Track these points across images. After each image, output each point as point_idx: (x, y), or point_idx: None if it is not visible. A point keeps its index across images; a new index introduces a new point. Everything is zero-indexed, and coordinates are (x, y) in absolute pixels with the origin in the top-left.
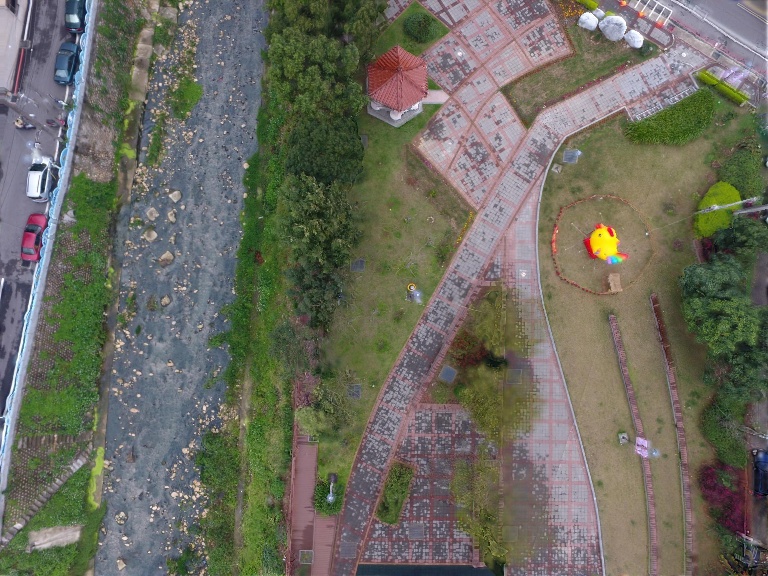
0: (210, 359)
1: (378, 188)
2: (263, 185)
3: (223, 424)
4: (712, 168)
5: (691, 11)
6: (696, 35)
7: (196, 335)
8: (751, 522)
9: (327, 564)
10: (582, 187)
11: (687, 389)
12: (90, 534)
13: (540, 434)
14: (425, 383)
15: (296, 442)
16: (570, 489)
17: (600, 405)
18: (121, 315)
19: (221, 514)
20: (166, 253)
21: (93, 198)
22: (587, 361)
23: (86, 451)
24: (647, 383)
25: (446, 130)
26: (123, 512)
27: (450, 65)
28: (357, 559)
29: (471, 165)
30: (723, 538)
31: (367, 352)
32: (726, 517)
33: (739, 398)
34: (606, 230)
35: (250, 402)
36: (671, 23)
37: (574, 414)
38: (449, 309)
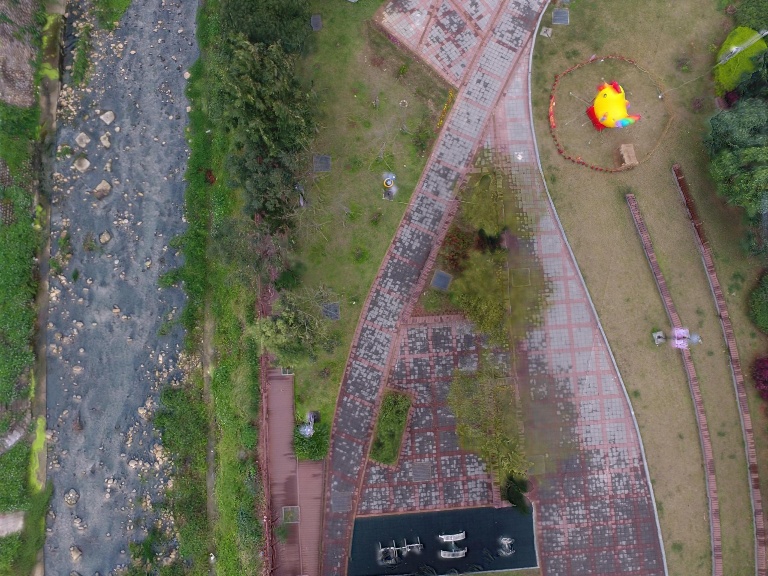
0: (162, 300)
1: (338, 73)
2: (207, 93)
3: (184, 375)
4: (727, 15)
5: None
6: None
7: (144, 274)
8: None
9: (317, 521)
10: (578, 51)
11: (728, 273)
12: (35, 519)
13: (559, 343)
14: (415, 293)
15: (267, 378)
16: (602, 405)
17: (627, 302)
18: (54, 259)
19: (189, 480)
20: (101, 183)
21: (8, 122)
22: (606, 251)
23: (24, 421)
24: (680, 270)
25: (412, 1)
26: (73, 490)
27: None
28: (353, 512)
29: (445, 38)
30: None
31: (343, 264)
32: None
33: None
34: (612, 88)
35: (213, 345)
36: None
37: (597, 315)
38: (436, 205)
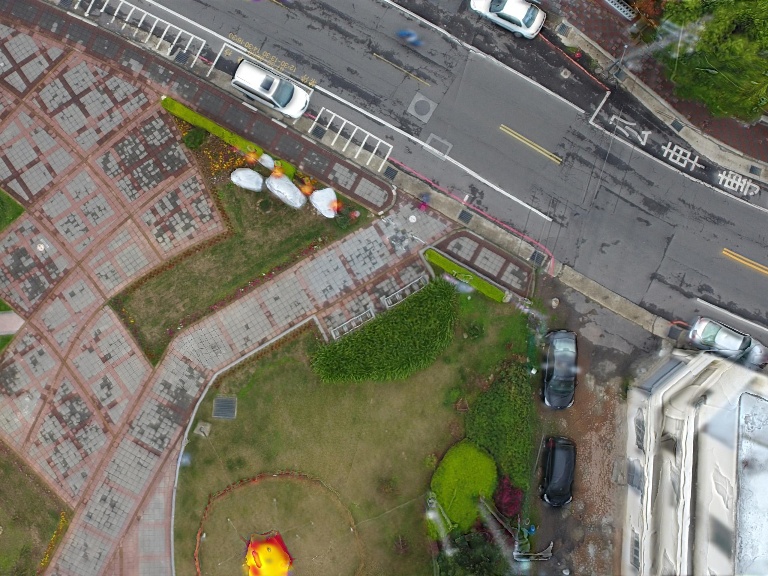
0: None
1: None
2: None
3: None
4: (457, 412)
5: (424, 144)
6: (433, 184)
7: None
8: None
9: None
10: (245, 457)
11: None
12: None
13: None
14: None
15: None
16: None
17: None
18: None
19: None
20: None
21: None
22: None
23: None
24: None
25: (20, 377)
26: None
27: (25, 268)
28: None
29: (62, 433)
30: None
31: None
32: None
33: None
34: (252, 554)
35: None
36: (392, 166)
37: None
38: None
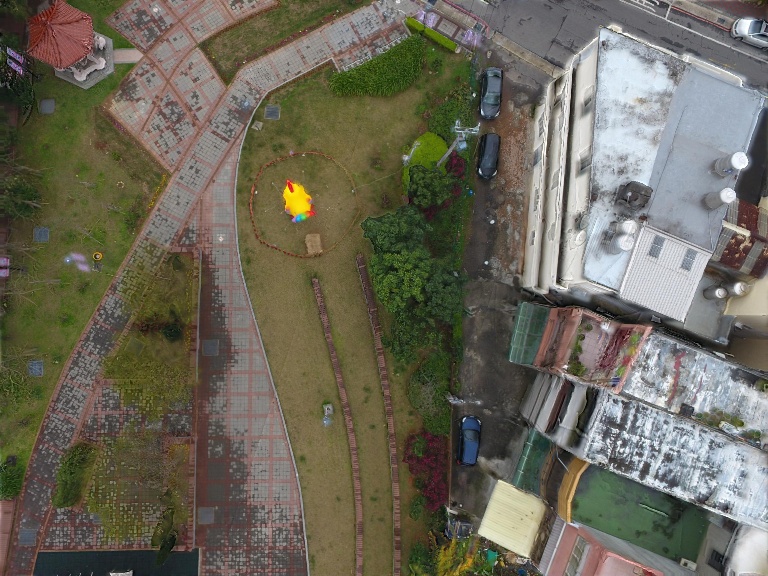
0: None
1: (64, 153)
2: None
3: None
4: (424, 119)
5: None
6: None
7: None
8: (465, 495)
9: (4, 553)
10: (284, 144)
11: None
12: None
13: (238, 408)
14: (109, 357)
15: None
16: (271, 466)
17: (303, 375)
18: None
19: None
20: None
21: None
22: (289, 328)
23: None
24: (353, 350)
25: (139, 90)
26: None
27: (145, 22)
28: (37, 547)
29: (165, 126)
30: (412, 512)
31: (49, 327)
32: (431, 490)
33: (401, 358)
34: None
35: None
36: None
37: (274, 385)
38: (140, 278)
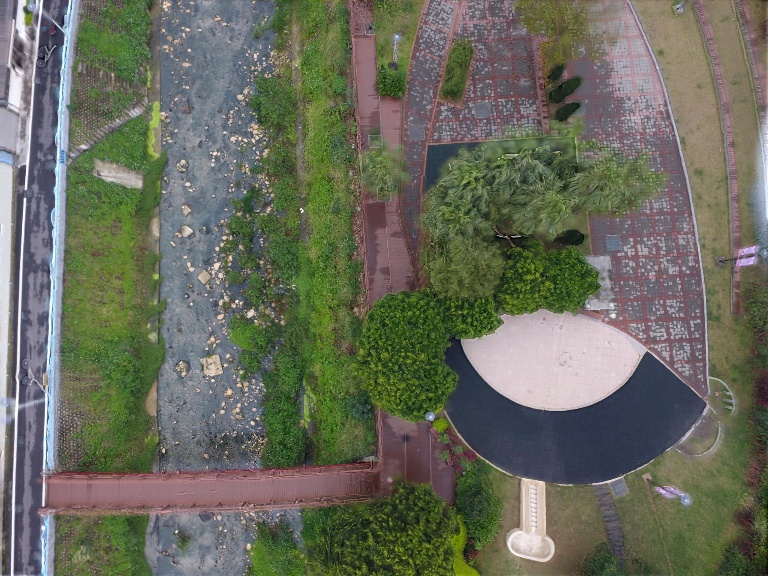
0: (256, 11)
1: None
2: None
3: (275, 69)
4: None
5: None
6: None
7: None
8: None
9: (397, 146)
10: None
11: None
12: (153, 181)
13: (594, 13)
14: None
15: None
16: (631, 62)
17: None
18: None
19: (282, 148)
20: None
21: None
22: None
23: (142, 104)
24: None
25: None
26: (184, 160)
27: None
28: (426, 140)
29: None
30: None
31: None
32: None
33: None
34: None
35: (300, 44)
36: None
37: None
38: None
